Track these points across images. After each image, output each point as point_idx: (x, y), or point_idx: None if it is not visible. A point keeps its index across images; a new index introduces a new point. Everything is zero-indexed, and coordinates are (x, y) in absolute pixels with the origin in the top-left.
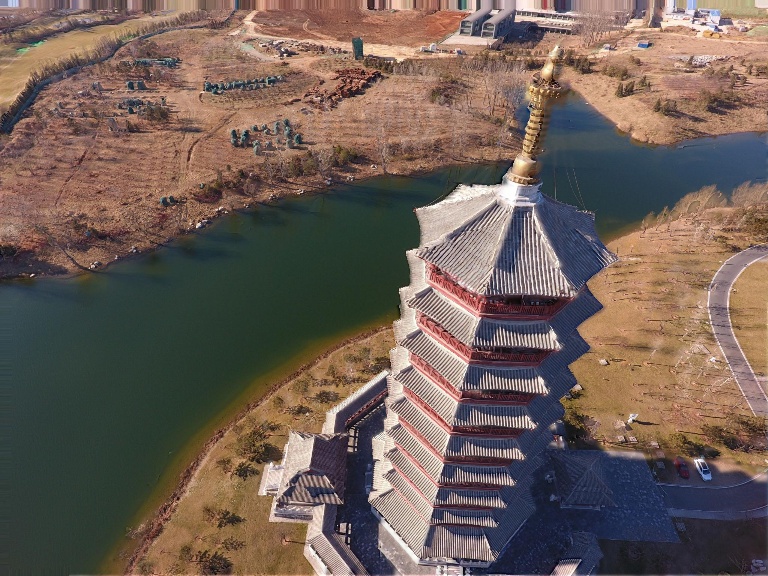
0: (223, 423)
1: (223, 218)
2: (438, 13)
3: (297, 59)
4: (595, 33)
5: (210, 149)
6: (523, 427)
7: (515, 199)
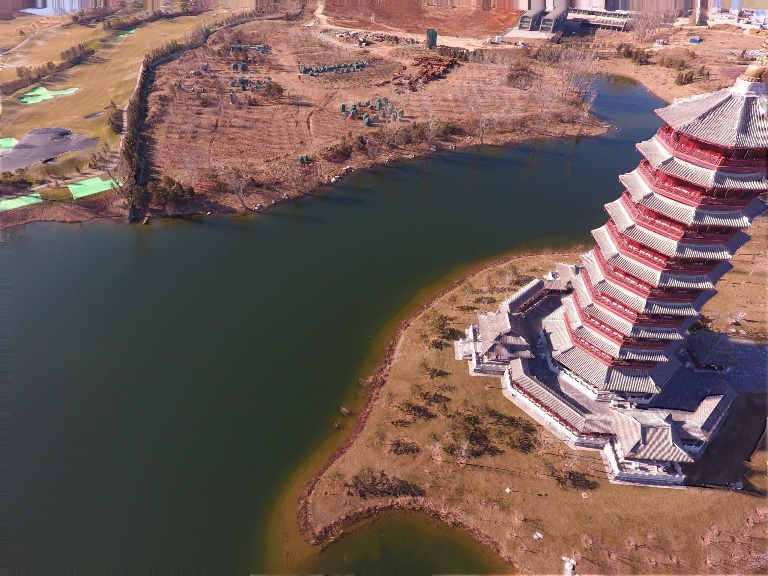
0: (405, 318)
1: (351, 175)
2: (494, 10)
3: (376, 48)
4: (647, 29)
5: (325, 120)
6: (723, 258)
7: (746, 93)
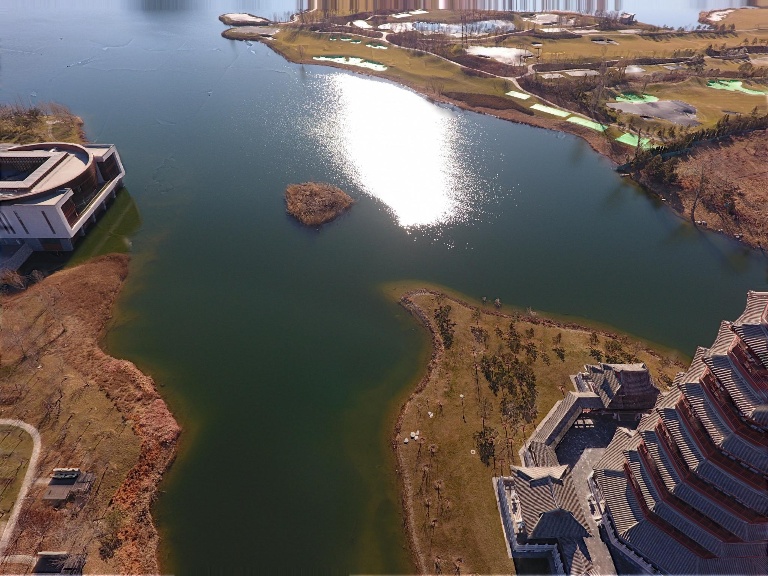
0: None
1: None
2: None
3: None
4: None
5: None
6: (741, 408)
7: None
